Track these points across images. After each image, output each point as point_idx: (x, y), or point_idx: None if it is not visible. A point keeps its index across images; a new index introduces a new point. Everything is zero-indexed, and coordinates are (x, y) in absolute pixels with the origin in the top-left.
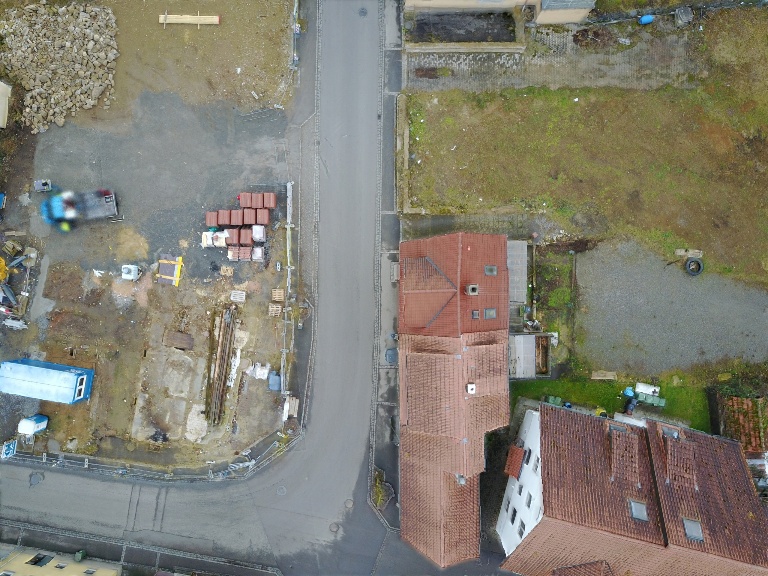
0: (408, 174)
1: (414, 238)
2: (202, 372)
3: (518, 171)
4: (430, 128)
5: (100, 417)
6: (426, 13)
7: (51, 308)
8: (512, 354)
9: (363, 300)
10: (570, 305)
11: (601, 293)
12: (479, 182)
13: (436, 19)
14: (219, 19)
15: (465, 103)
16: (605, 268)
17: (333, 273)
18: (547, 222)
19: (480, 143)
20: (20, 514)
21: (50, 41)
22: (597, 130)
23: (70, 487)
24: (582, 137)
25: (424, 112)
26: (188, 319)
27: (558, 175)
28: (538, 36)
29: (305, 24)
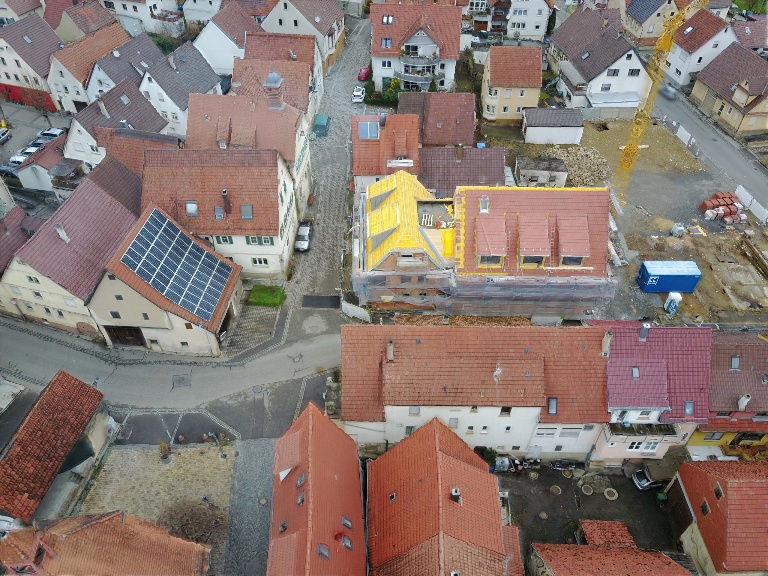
0: None
1: None
2: (755, 271)
3: None
4: None
5: (707, 301)
6: (746, 136)
7: (637, 254)
8: None
9: None
10: None
11: None
12: None
13: (753, 137)
14: (649, 146)
15: None
16: None
17: None
18: None
19: None
20: None
21: None
22: None
23: None
24: None
25: None
26: (724, 250)
27: None
28: None
29: None
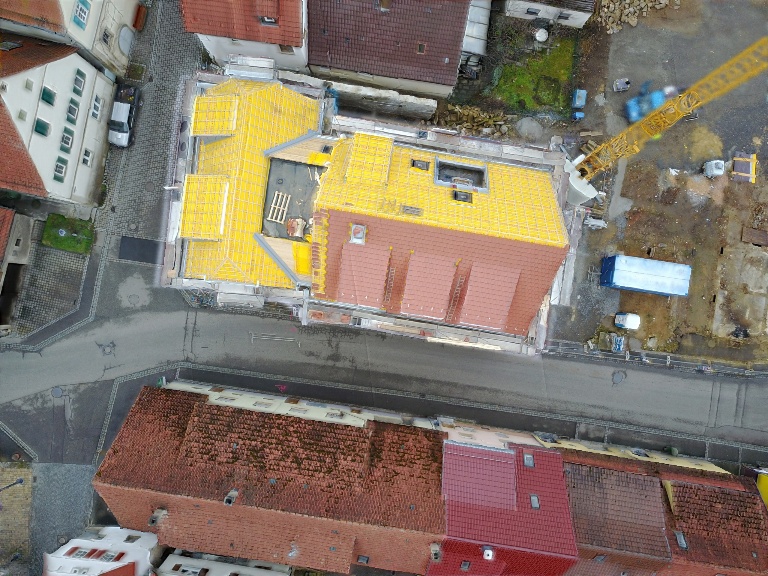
0: None
1: None
2: None
3: None
4: None
5: (680, 315)
6: None
7: (629, 207)
8: None
9: None
10: None
11: None
12: None
13: None
14: None
15: None
16: None
17: None
18: None
19: None
20: (604, 413)
21: None
22: None
23: (652, 385)
24: None
25: None
26: (763, 216)
27: None
28: None
29: None
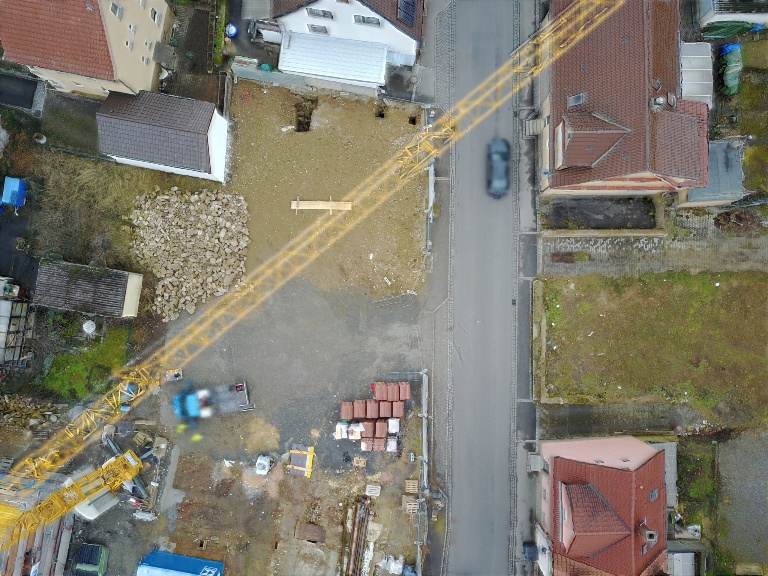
0: (545, 362)
1: (551, 428)
2: (335, 566)
3: (658, 358)
4: (566, 313)
5: None
6: (562, 197)
7: (181, 499)
8: (670, 573)
9: (498, 490)
10: (714, 499)
11: (745, 484)
12: (617, 369)
13: (573, 203)
14: (352, 205)
15: (602, 288)
16: (749, 458)
17: (467, 462)
18: (689, 412)
19: (618, 329)
20: None
21: (182, 229)
22: (740, 316)
23: None
24: (724, 323)
25: (560, 297)
26: (320, 510)
27: (700, 363)
28: (677, 219)
29: (438, 208)
